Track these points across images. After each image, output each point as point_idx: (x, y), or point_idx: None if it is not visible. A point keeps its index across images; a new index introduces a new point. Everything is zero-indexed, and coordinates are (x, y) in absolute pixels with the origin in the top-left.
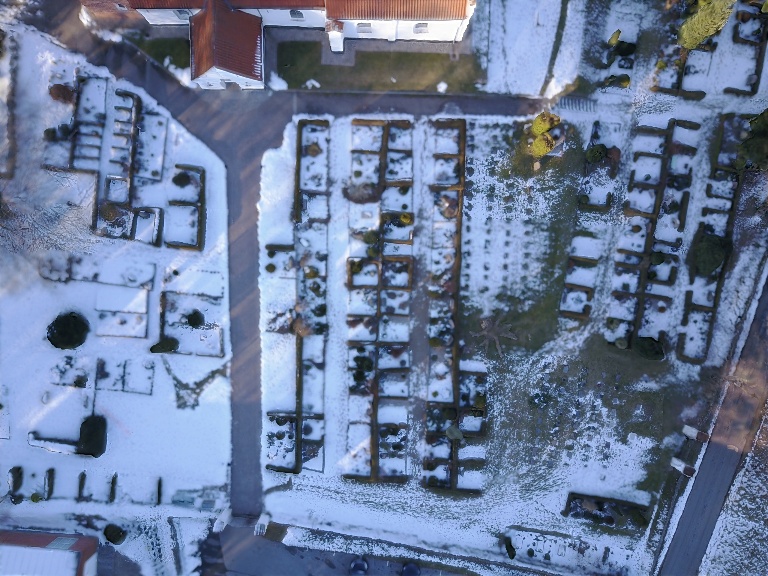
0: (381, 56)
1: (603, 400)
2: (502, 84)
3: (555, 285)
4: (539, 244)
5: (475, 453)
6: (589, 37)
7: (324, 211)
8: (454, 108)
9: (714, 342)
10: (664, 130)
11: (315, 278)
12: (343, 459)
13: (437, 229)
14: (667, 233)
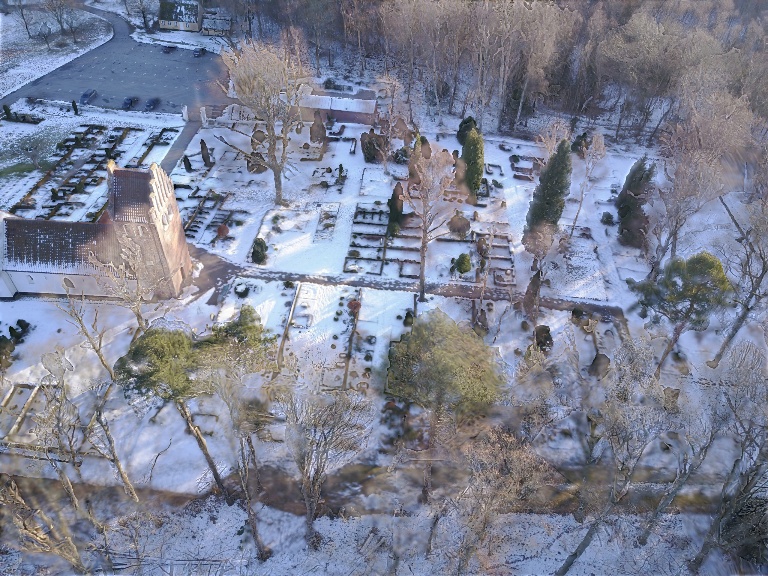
0: None
1: None
2: None
3: None
4: None
5: None
6: None
7: (100, 199)
8: None
9: None
10: None
11: None
12: (141, 135)
13: None
14: None
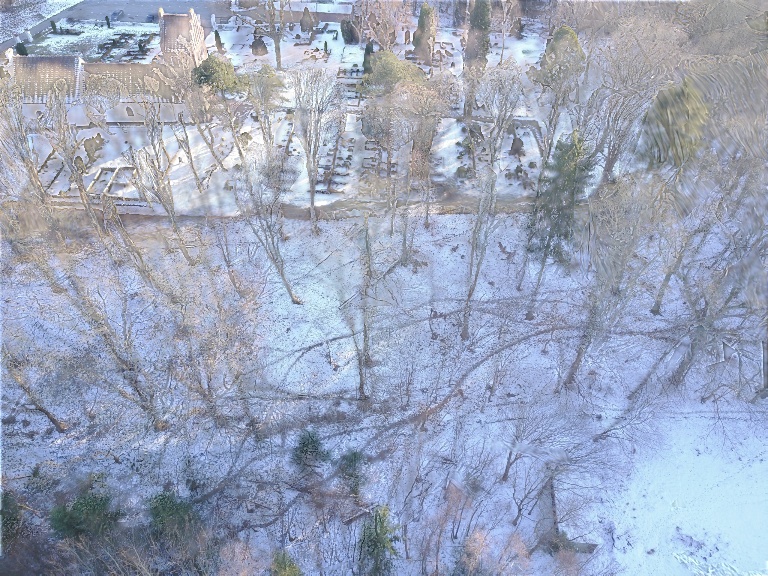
0: None
1: None
2: None
3: None
4: None
5: None
6: None
7: None
8: None
9: None
10: None
11: None
12: None
13: None
14: None
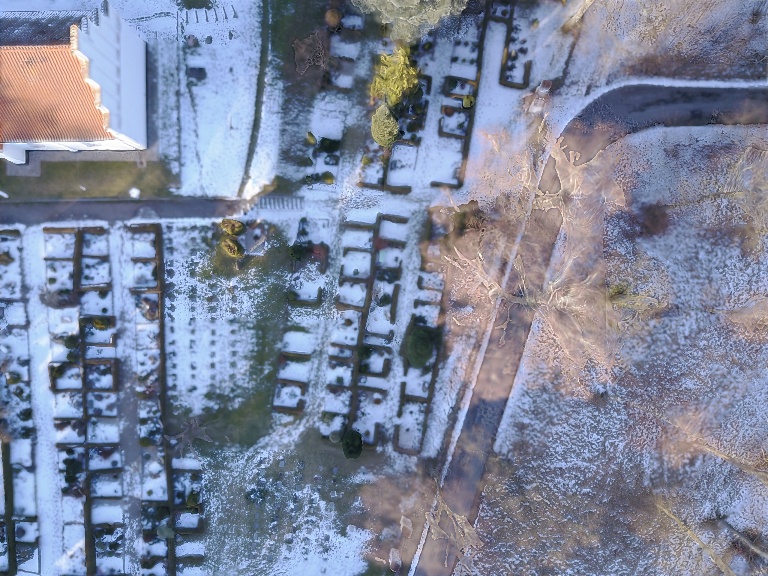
0: (67, 166)
1: (320, 493)
2: (198, 187)
3: (265, 381)
4: (246, 342)
5: (194, 550)
6: (288, 137)
7: (22, 318)
8: (149, 212)
9: (430, 432)
10: (370, 225)
11: (18, 383)
12: (60, 560)
13: (140, 331)
14: (380, 325)
